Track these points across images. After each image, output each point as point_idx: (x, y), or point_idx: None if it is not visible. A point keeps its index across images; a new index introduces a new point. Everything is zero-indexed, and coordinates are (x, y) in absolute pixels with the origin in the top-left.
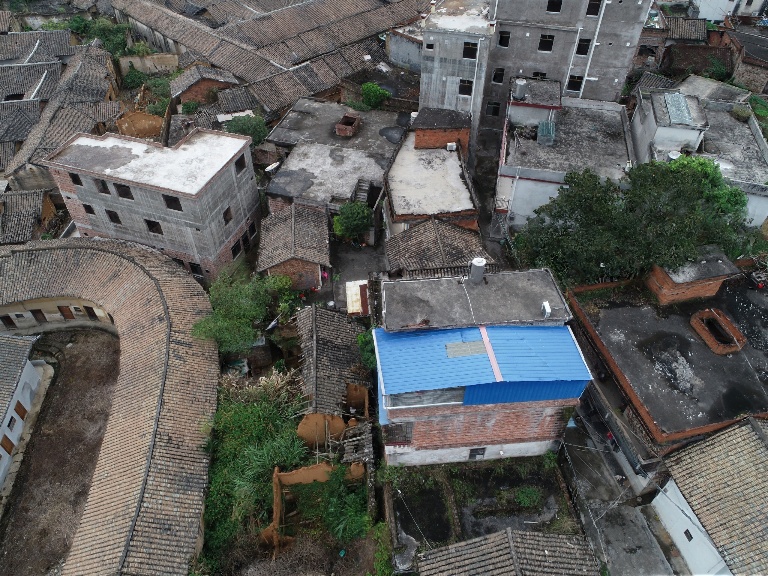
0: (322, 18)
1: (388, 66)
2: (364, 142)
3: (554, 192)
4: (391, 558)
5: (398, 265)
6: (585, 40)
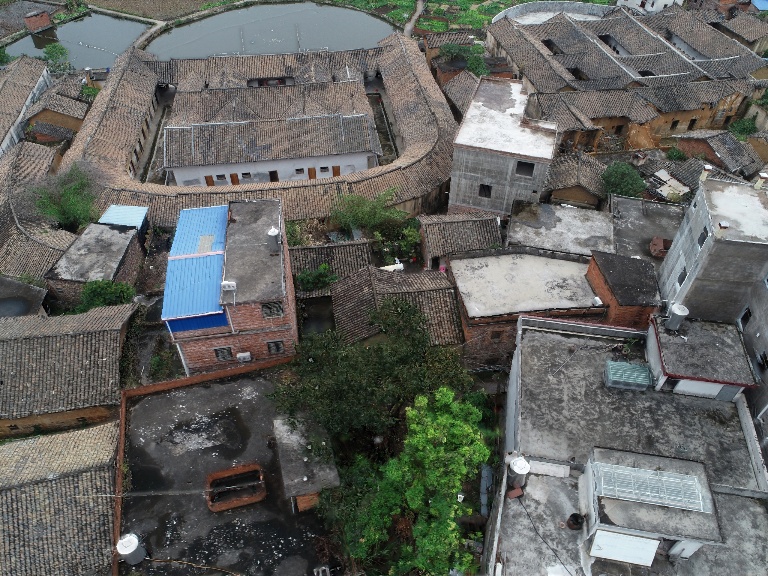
0: None
1: None
2: None
3: None
4: None
5: None
6: None
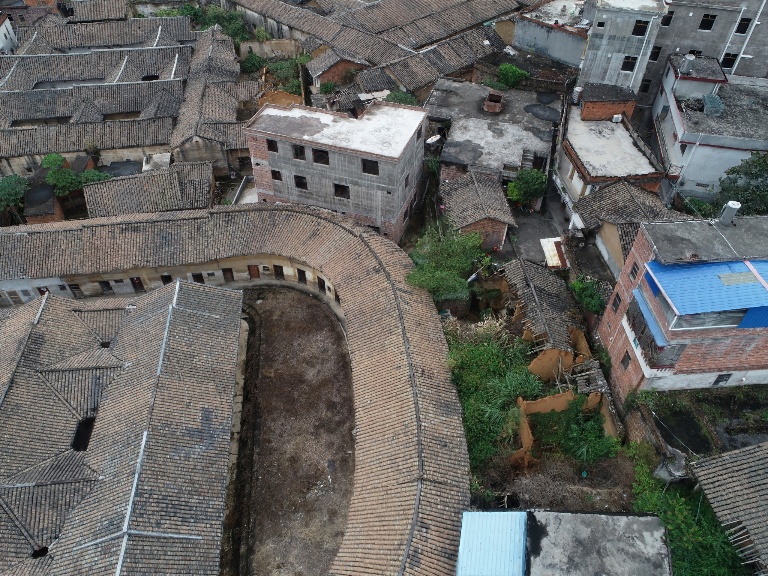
0: (425, 7)
1: (514, 50)
2: (513, 118)
3: (730, 158)
4: (653, 470)
5: (596, 222)
6: (746, 19)
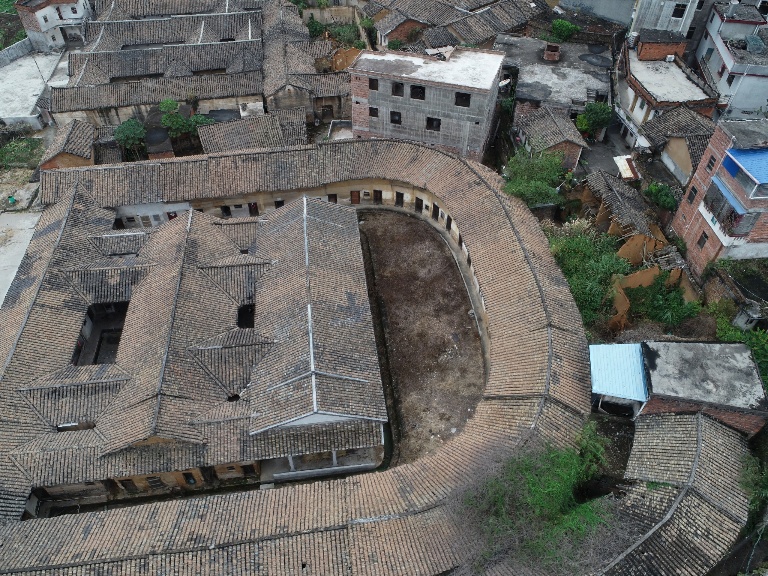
0: None
1: (562, 9)
2: (571, 65)
3: None
4: (732, 319)
5: (664, 139)
6: None
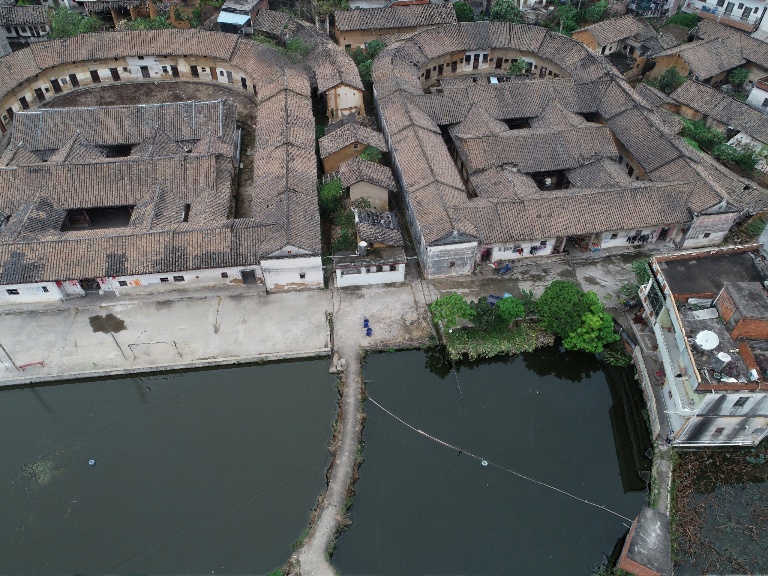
0: None
1: None
2: None
3: None
4: None
5: None
6: None
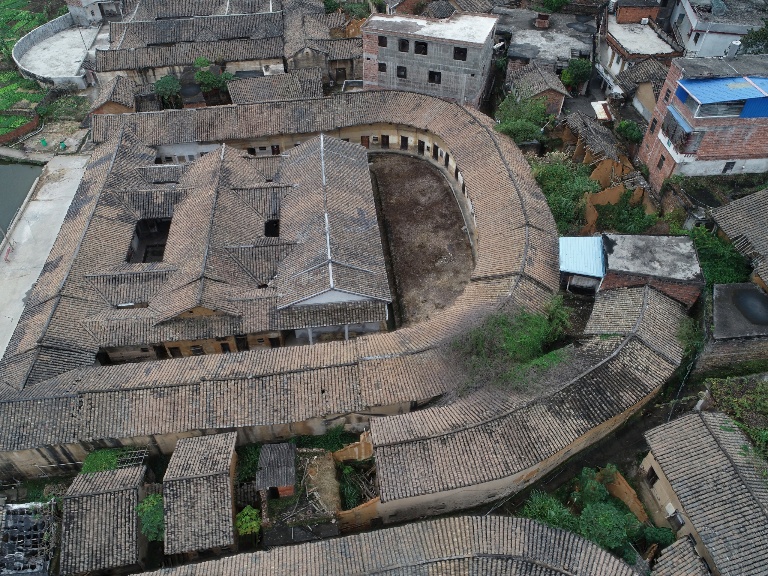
0: None
1: None
2: None
3: None
4: (683, 224)
5: (634, 85)
6: None
